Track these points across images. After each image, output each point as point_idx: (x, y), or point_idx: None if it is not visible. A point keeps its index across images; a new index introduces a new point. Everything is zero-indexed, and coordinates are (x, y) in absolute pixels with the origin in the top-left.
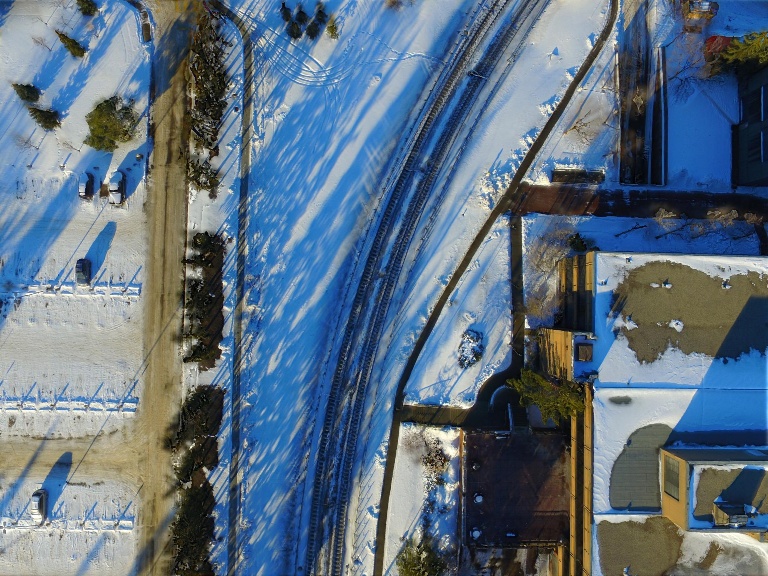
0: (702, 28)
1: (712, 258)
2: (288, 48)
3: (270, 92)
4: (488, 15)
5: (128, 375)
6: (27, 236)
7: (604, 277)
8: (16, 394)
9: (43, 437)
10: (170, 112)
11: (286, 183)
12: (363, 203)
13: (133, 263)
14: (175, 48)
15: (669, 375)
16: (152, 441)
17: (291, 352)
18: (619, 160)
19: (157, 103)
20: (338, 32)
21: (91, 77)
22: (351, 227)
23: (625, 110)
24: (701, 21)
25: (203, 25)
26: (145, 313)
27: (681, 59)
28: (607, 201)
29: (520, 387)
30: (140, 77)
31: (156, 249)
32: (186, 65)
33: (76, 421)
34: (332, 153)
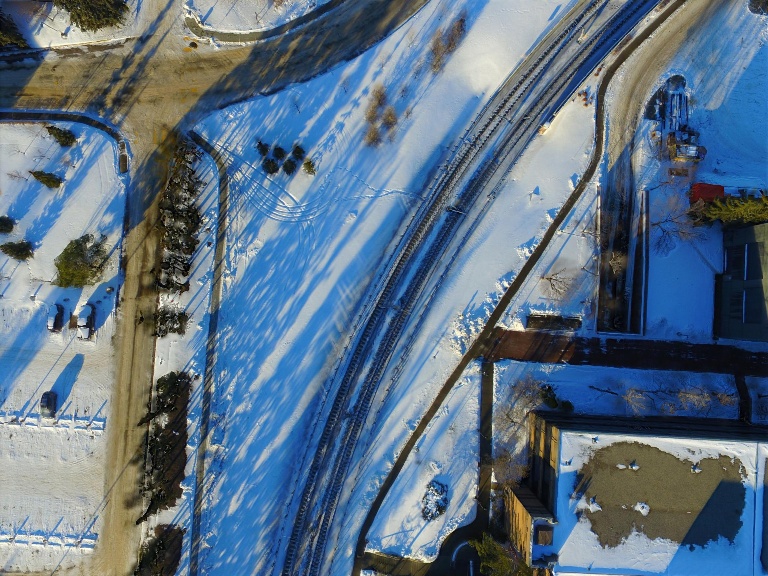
0: (689, 171)
1: (682, 441)
2: (264, 183)
3: (244, 227)
4: (470, 149)
5: (88, 510)
6: None
7: (568, 457)
8: None
9: (1, 570)
10: (143, 244)
11: (256, 320)
12: (333, 341)
13: (99, 396)
14: (151, 180)
15: (632, 561)
16: None
17: (253, 494)
18: (597, 307)
19: (130, 235)
20: (315, 168)
21: (66, 208)
22: (320, 366)
23: (606, 251)
24: (688, 164)
25: (179, 159)
26: (108, 448)
27: (665, 203)
28: (583, 349)
29: (481, 552)
30: (114, 209)
31: (122, 383)
32: (161, 197)
33: (34, 555)
34: (304, 291)
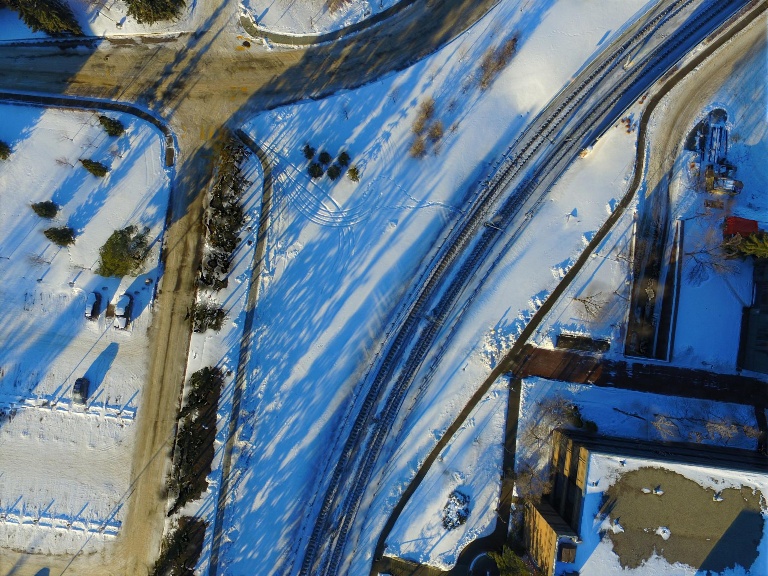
0: (724, 204)
1: (707, 469)
2: (308, 186)
3: (285, 228)
4: (511, 167)
5: (113, 498)
6: (30, 348)
7: (596, 478)
8: (1, 506)
9: (23, 551)
10: (184, 239)
11: (291, 321)
12: (365, 347)
13: (131, 386)
14: (196, 175)
15: None
16: (130, 566)
17: (277, 492)
18: (626, 331)
19: (172, 228)
20: (359, 175)
21: (110, 197)
22: (351, 371)
23: (638, 276)
24: (724, 196)
25: (226, 157)
26: (137, 438)
27: (699, 234)
28: (609, 371)
29: (501, 564)
30: (158, 201)
31: (155, 375)
32: (205, 193)
33: (57, 538)
34: (340, 296)
